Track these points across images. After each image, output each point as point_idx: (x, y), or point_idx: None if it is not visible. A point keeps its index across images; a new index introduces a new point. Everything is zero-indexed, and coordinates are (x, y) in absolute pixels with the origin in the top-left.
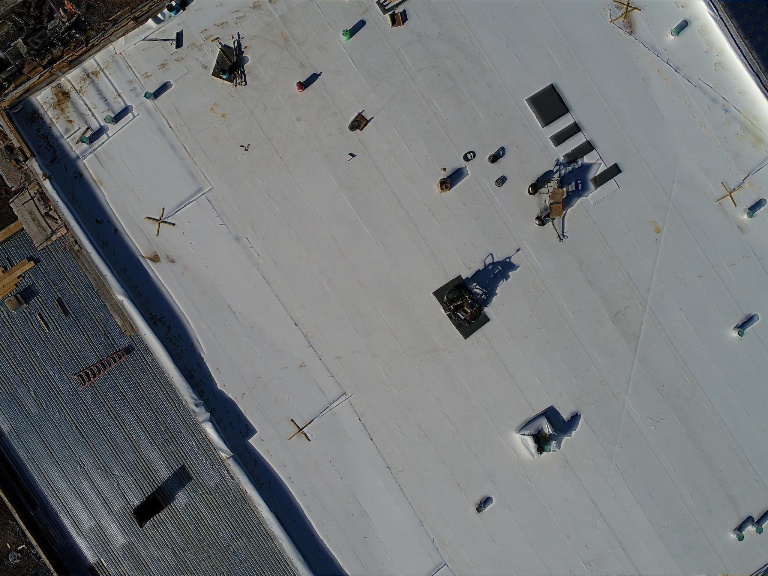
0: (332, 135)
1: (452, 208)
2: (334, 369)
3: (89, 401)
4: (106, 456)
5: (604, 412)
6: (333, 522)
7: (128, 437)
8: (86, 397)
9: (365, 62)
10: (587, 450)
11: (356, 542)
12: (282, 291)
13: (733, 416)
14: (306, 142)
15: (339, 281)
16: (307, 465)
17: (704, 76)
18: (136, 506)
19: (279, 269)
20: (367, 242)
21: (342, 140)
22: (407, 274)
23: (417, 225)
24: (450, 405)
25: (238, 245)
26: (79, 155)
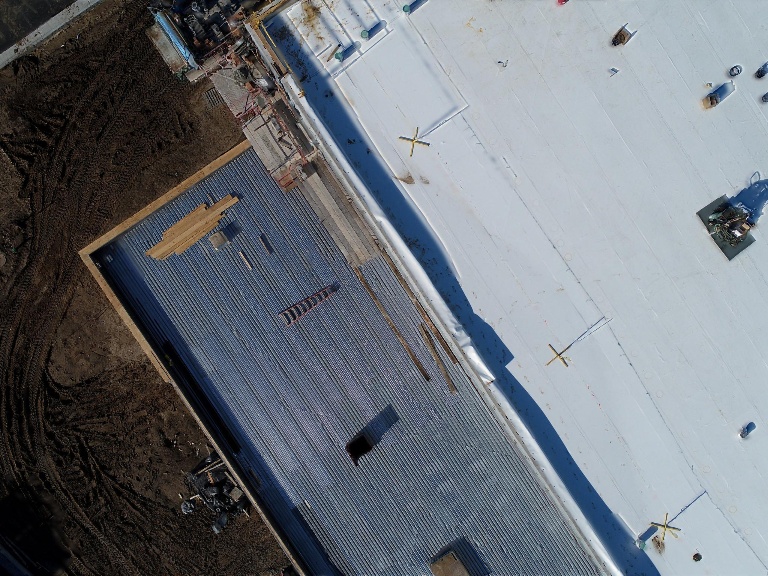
0: (594, 50)
1: (717, 125)
2: (593, 292)
3: (293, 340)
4: (310, 396)
5: None
6: (590, 449)
7: (333, 377)
8: (290, 336)
9: None
10: None
11: (614, 470)
12: (540, 212)
13: None
14: (567, 57)
15: (599, 201)
16: (565, 391)
17: None
18: (341, 447)
19: (537, 190)
20: (629, 161)
21: (604, 55)
22: (670, 194)
23: (681, 143)
24: (712, 329)
25: (494, 165)
26: (330, 73)
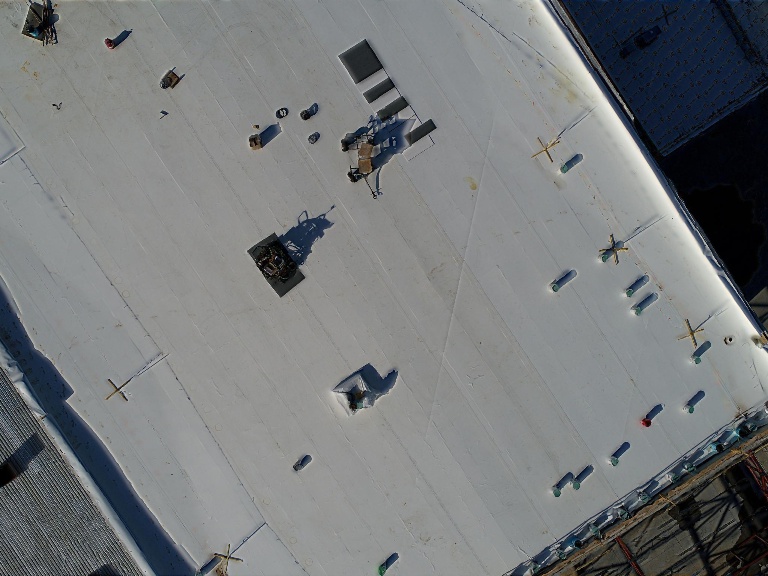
0: (144, 93)
1: (265, 165)
2: (151, 328)
3: None
4: None
5: (421, 369)
6: (152, 482)
7: None
8: None
9: (175, 19)
10: (405, 407)
11: (176, 502)
12: (97, 250)
13: (551, 372)
14: (118, 100)
15: (154, 240)
16: (125, 425)
17: (519, 31)
18: None
19: (94, 228)
20: (181, 200)
21: (154, 98)
22: (222, 232)
23: (230, 183)
24: (267, 363)
25: (53, 205)
26: None
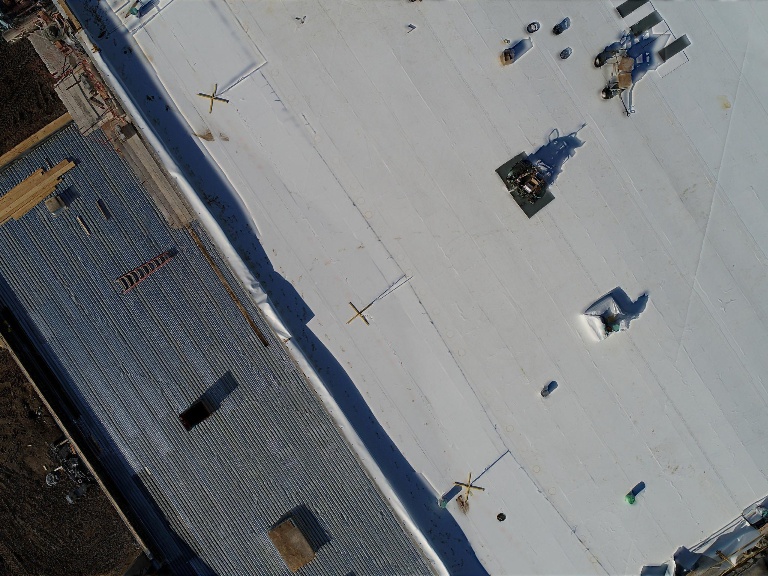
0: (391, 6)
1: (516, 82)
2: (393, 250)
3: (132, 306)
4: (149, 362)
5: (672, 293)
6: (393, 408)
7: (172, 343)
8: (129, 302)
9: None
10: (654, 332)
11: (416, 429)
12: (340, 170)
13: None
14: (364, 14)
15: (398, 159)
16: (366, 349)
17: None
18: None
19: (336, 147)
20: (427, 118)
21: (401, 11)
22: (469, 151)
23: (479, 99)
24: (513, 287)
25: (294, 122)
26: (129, 29)
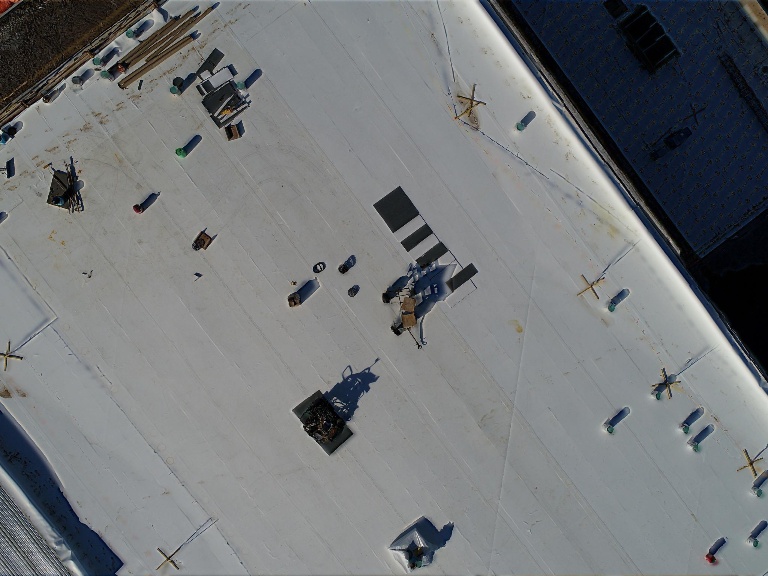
0: (176, 256)
1: (305, 322)
2: (198, 494)
3: None
4: None
5: (477, 519)
6: None
7: (20, 554)
8: None
9: (204, 178)
10: (463, 559)
11: None
12: (138, 418)
13: (610, 513)
14: (150, 265)
15: (196, 404)
16: None
17: (556, 167)
18: None
19: (133, 396)
20: (221, 363)
21: (187, 260)
22: (265, 392)
23: (271, 342)
24: (319, 523)
25: (89, 374)
26: None
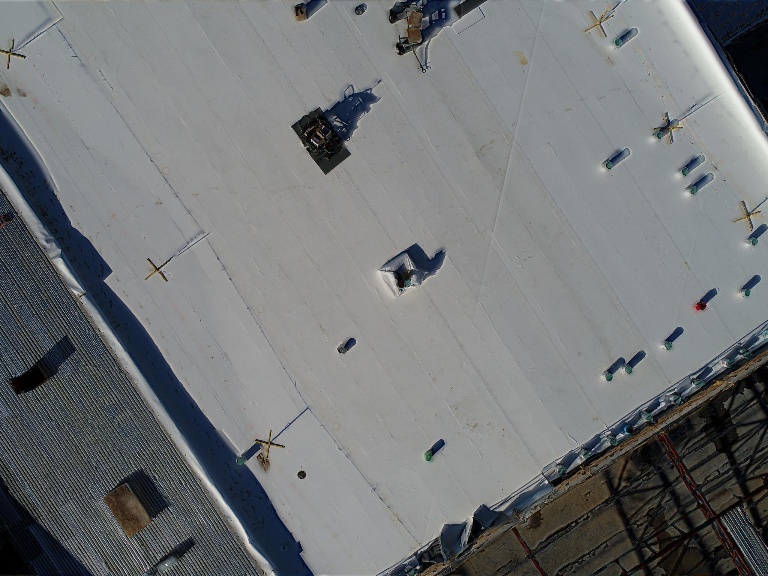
0: None
1: (311, 37)
2: (191, 207)
3: None
4: None
5: (469, 250)
6: (192, 365)
7: (9, 307)
8: None
9: None
10: (452, 289)
11: (216, 386)
12: (137, 126)
13: (603, 254)
14: None
15: (195, 115)
16: (164, 306)
17: None
18: None
19: (133, 103)
20: (223, 74)
21: None
22: (265, 107)
23: (275, 55)
24: (311, 243)
25: (91, 78)
26: None
